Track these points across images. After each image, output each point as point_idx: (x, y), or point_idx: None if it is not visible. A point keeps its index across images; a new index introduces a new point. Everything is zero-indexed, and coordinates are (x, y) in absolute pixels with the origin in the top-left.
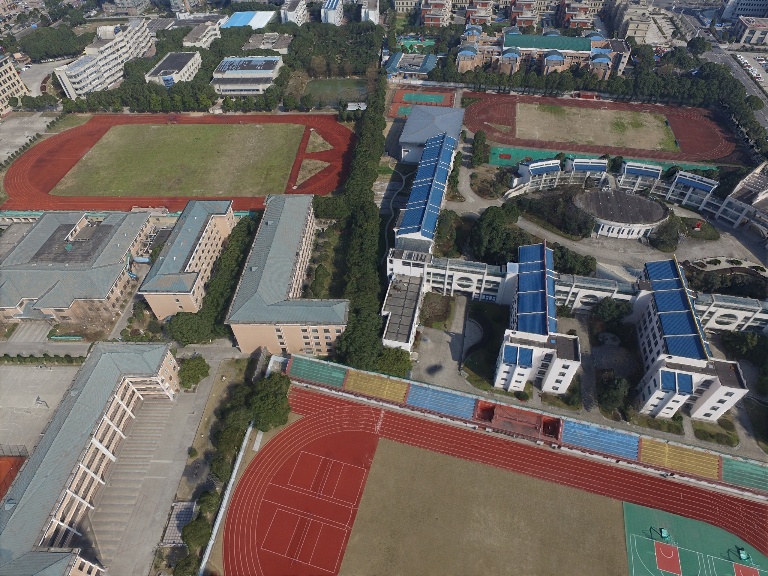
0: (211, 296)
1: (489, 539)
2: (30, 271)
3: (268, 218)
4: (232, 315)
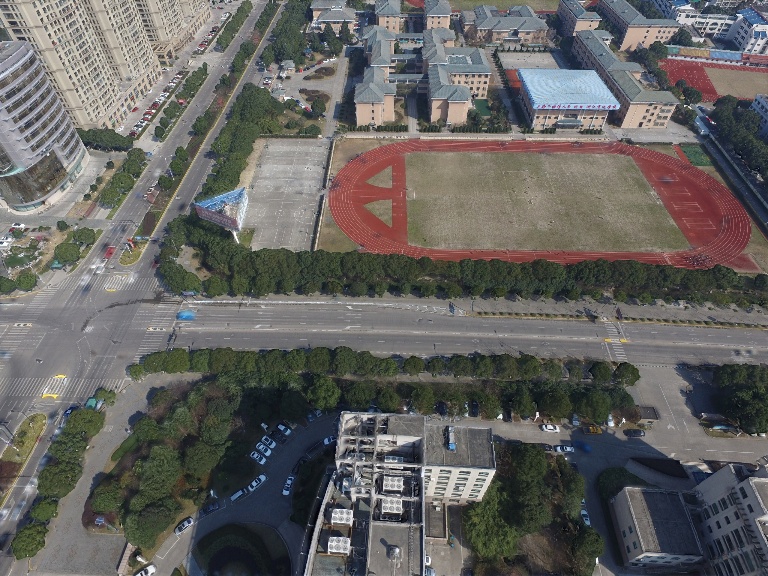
0: (602, 26)
1: (765, 83)
2: (509, 17)
3: (610, 1)
4: (631, 22)
